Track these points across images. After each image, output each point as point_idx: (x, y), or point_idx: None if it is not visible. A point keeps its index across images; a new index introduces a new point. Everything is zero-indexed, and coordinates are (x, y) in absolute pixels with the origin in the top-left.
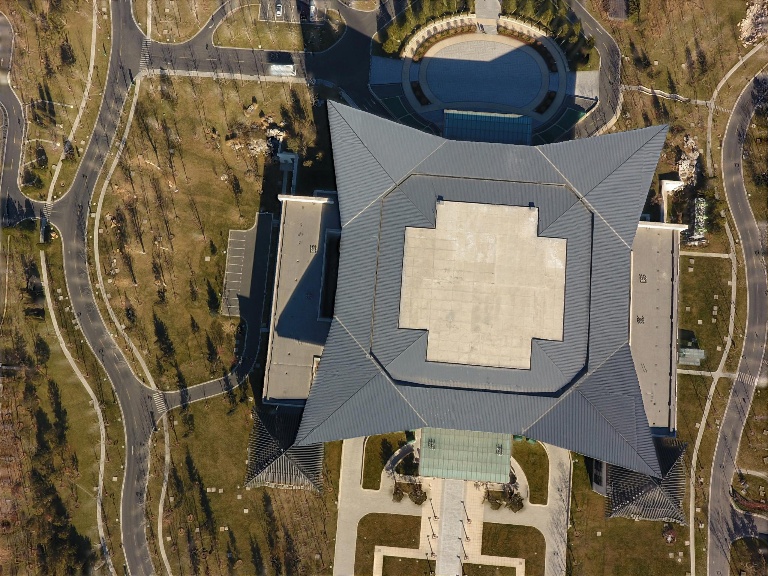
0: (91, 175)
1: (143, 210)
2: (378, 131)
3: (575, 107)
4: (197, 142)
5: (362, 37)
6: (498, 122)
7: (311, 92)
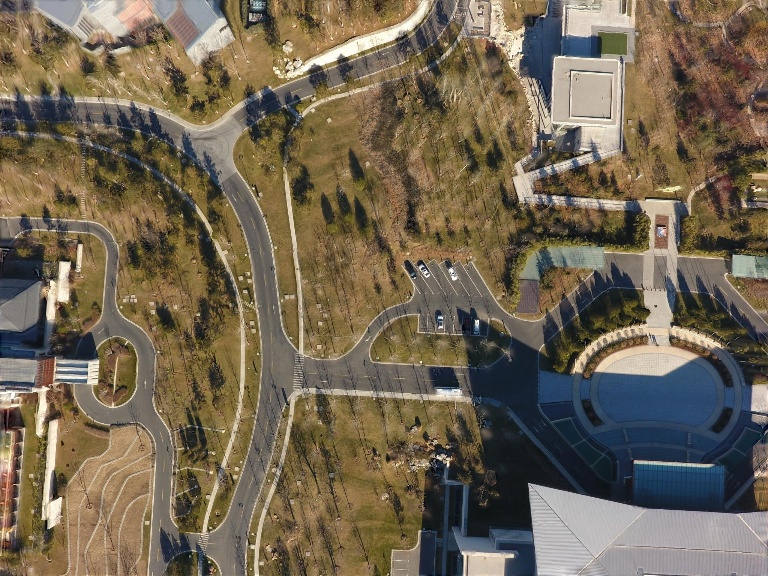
0: (247, 504)
1: (306, 542)
2: (579, 509)
3: (752, 425)
4: (357, 464)
5: (529, 350)
6: (690, 472)
7: (477, 412)
